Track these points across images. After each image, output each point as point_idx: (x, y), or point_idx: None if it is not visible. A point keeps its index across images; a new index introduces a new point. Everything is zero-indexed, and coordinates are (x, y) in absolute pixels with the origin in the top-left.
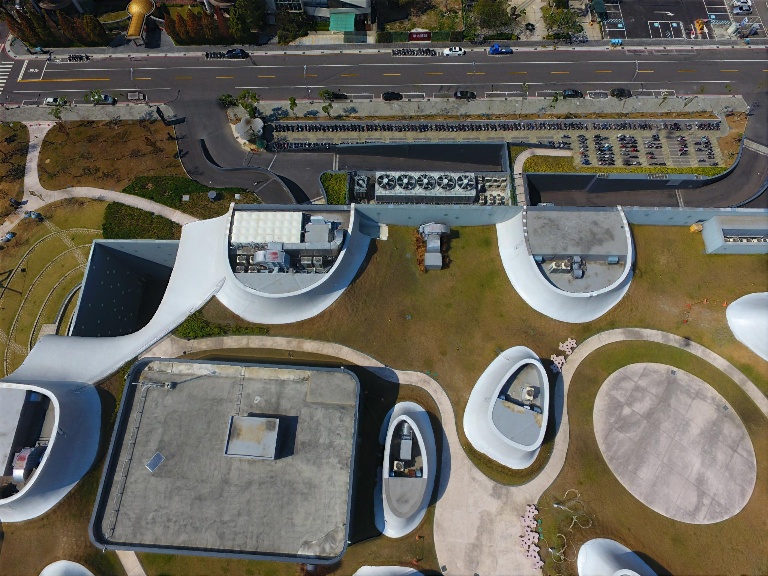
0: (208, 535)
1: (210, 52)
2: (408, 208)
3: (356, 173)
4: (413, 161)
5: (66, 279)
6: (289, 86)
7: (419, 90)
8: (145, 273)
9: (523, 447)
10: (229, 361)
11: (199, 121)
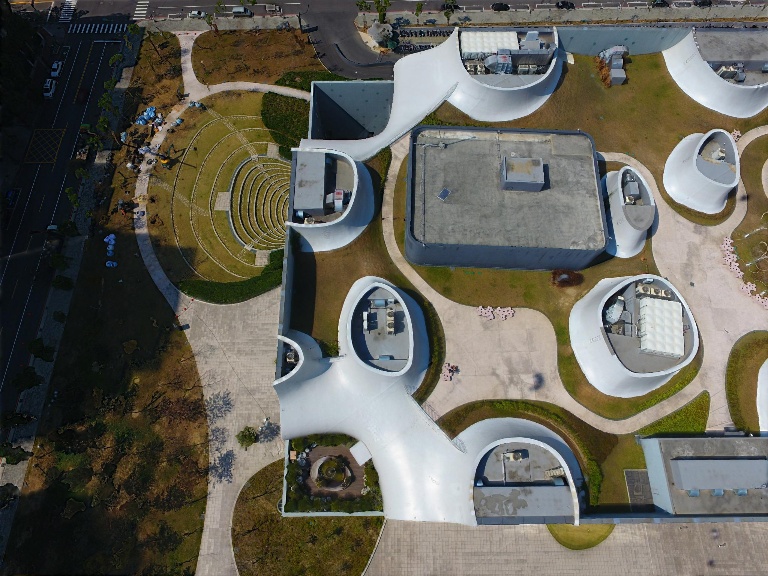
0: (498, 239)
1: None
2: (599, 30)
3: None
4: None
5: (233, 156)
6: (407, 0)
7: (523, 2)
8: (328, 130)
9: (725, 185)
10: None
11: (330, 29)
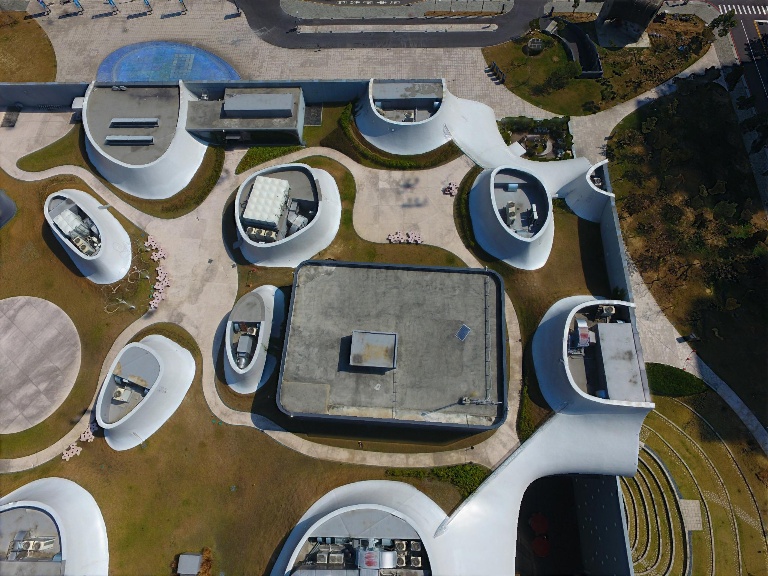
0: (408, 279)
1: None
2: None
3: None
4: None
5: None
6: None
7: None
8: None
9: (139, 346)
10: (424, 438)
11: None
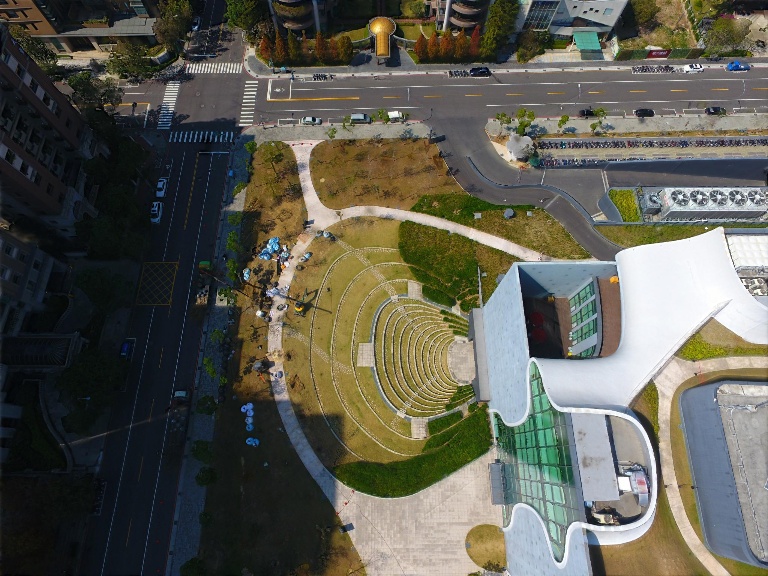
0: None
1: (454, 70)
2: None
3: (641, 189)
4: (675, 176)
5: (370, 298)
6: (540, 103)
7: (669, 106)
8: None
9: None
10: None
11: (460, 139)
